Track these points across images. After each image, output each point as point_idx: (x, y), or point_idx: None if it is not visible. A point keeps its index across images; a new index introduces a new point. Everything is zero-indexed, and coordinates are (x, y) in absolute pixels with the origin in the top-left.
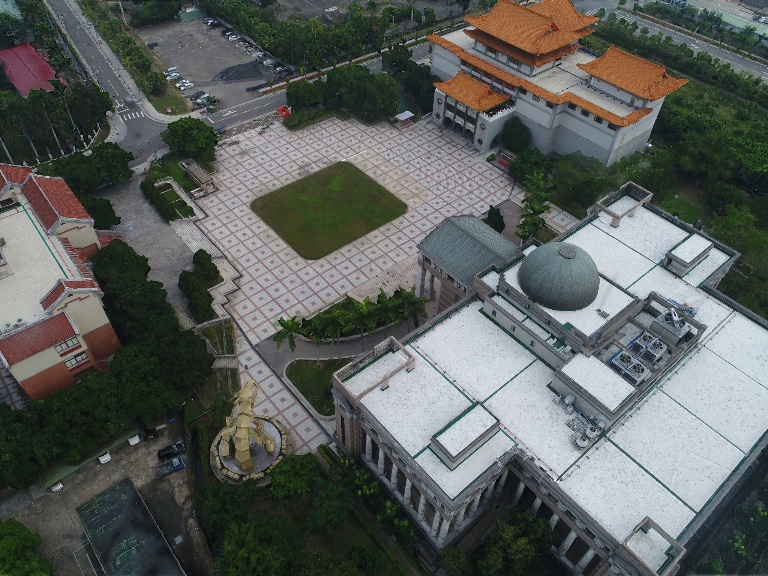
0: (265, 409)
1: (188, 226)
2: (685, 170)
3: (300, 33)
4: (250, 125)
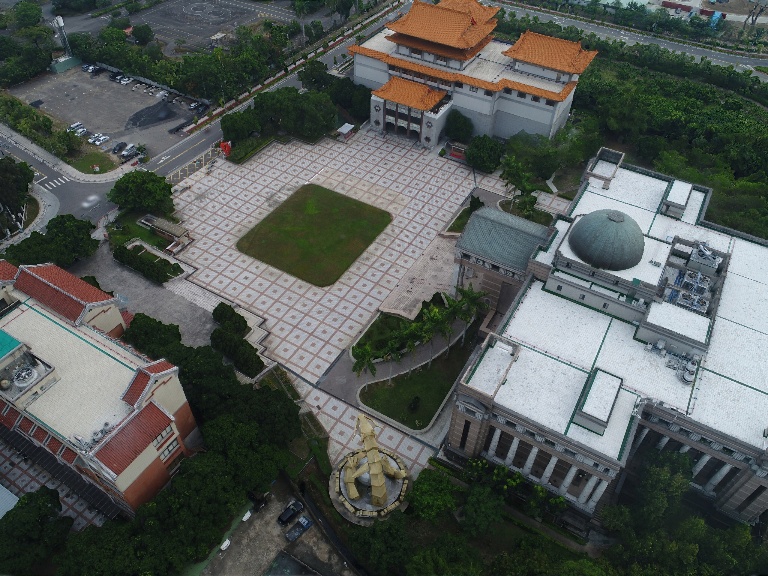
0: (359, 442)
1: (182, 284)
2: (612, 130)
3: (209, 64)
4: (192, 167)
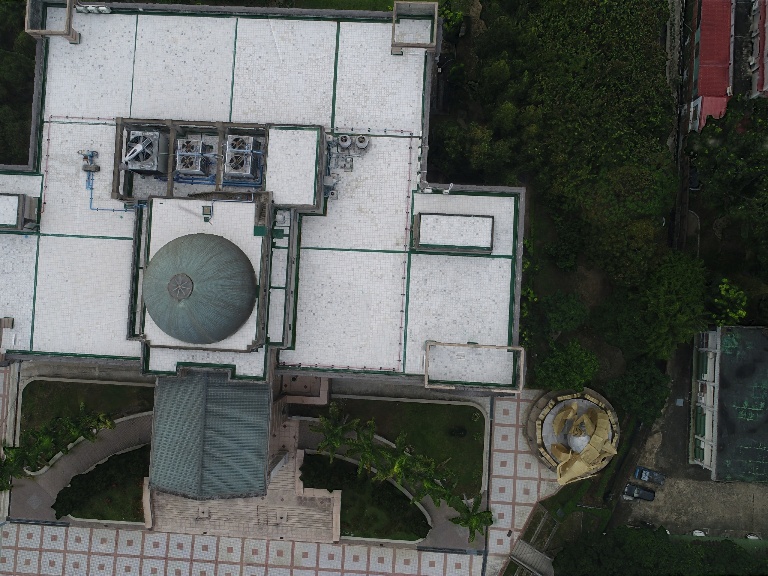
0: (527, 468)
1: None
2: None
3: None
4: None
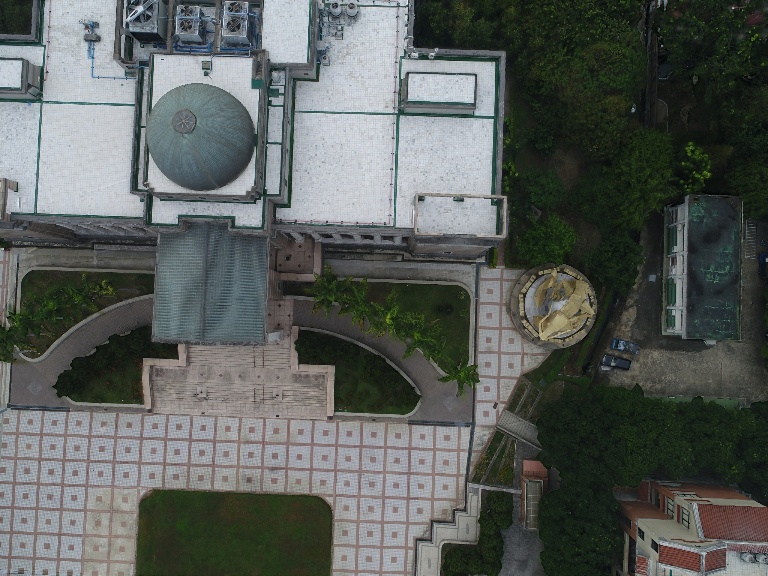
0: (511, 343)
1: None
2: None
3: None
4: None
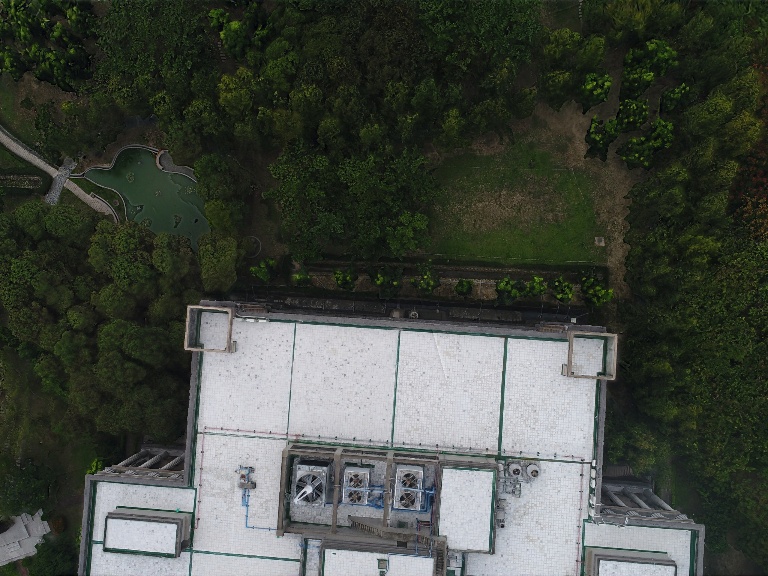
0: None
1: None
2: None
3: None
4: None
